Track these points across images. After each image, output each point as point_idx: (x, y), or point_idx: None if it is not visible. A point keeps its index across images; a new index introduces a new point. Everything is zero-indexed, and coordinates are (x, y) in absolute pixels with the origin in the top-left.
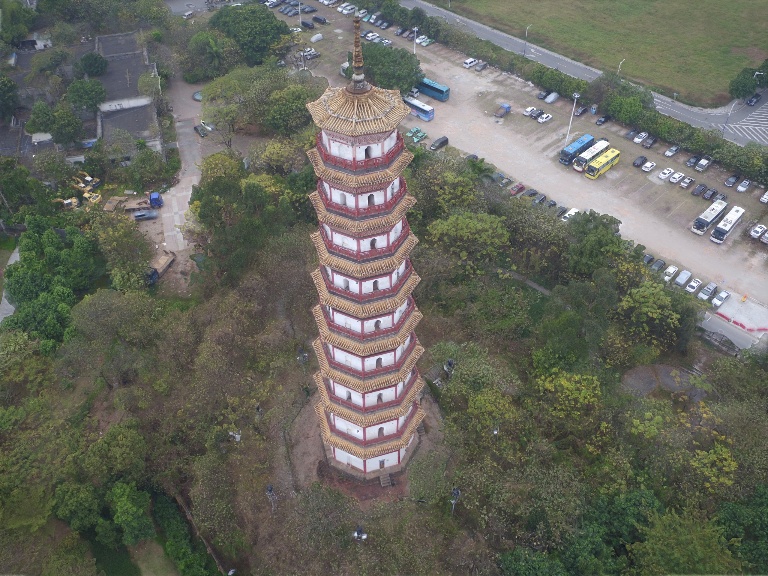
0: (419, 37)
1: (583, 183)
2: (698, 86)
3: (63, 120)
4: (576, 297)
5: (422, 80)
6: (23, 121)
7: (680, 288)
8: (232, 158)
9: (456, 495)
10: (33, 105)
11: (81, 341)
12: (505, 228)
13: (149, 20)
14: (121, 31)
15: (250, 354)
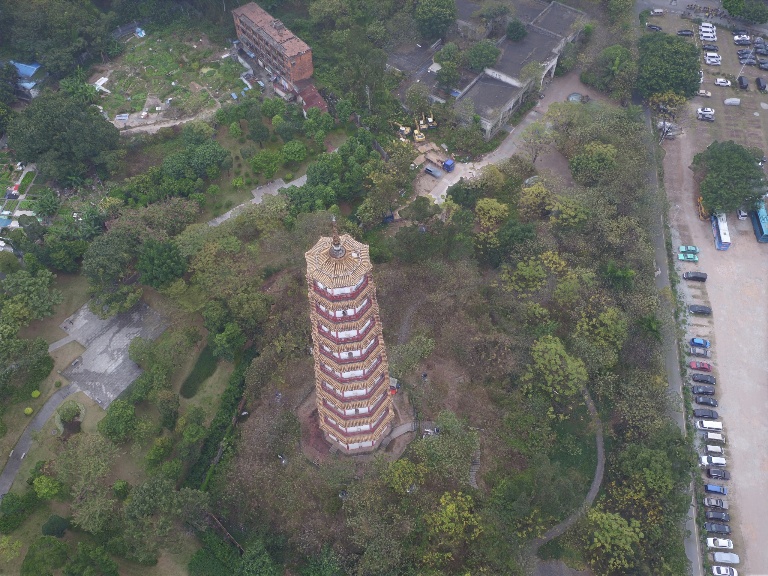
0: None
1: None
2: None
3: (445, 70)
4: (554, 475)
5: (757, 209)
6: (441, 47)
7: (712, 561)
8: None
9: None
10: (447, 43)
11: (285, 236)
12: (611, 386)
13: (609, 5)
14: (578, 5)
15: None
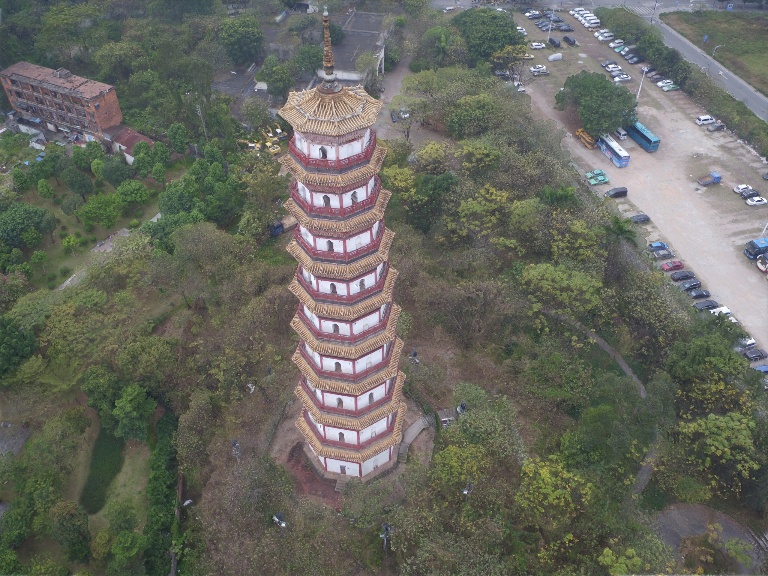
0: (663, 80)
1: (758, 284)
2: None
3: (278, 75)
4: None
5: (634, 124)
6: (259, 69)
7: None
8: (400, 147)
9: (386, 531)
10: (266, 57)
11: (166, 258)
12: (615, 298)
13: (407, 6)
14: (378, 11)
15: None
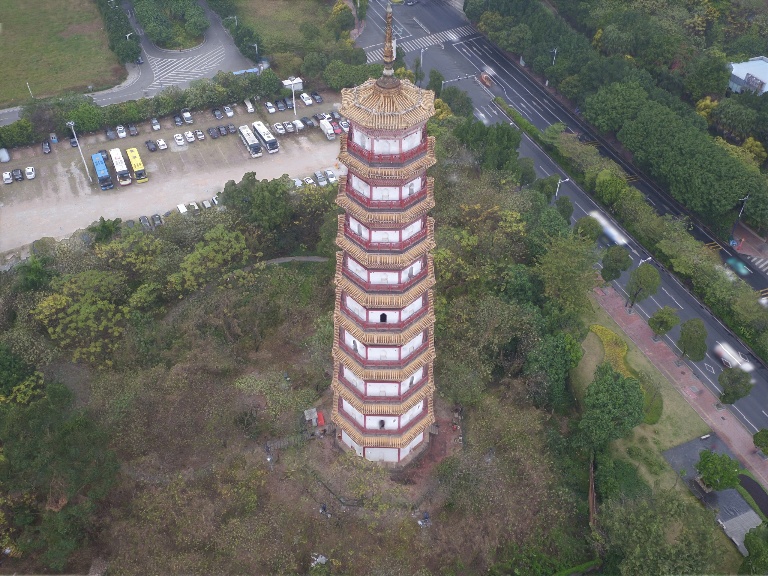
0: None
1: (146, 189)
2: (89, 73)
3: None
4: None
5: None
6: None
7: None
8: None
9: None
10: None
11: None
12: None
13: None
14: None
15: (239, 505)
